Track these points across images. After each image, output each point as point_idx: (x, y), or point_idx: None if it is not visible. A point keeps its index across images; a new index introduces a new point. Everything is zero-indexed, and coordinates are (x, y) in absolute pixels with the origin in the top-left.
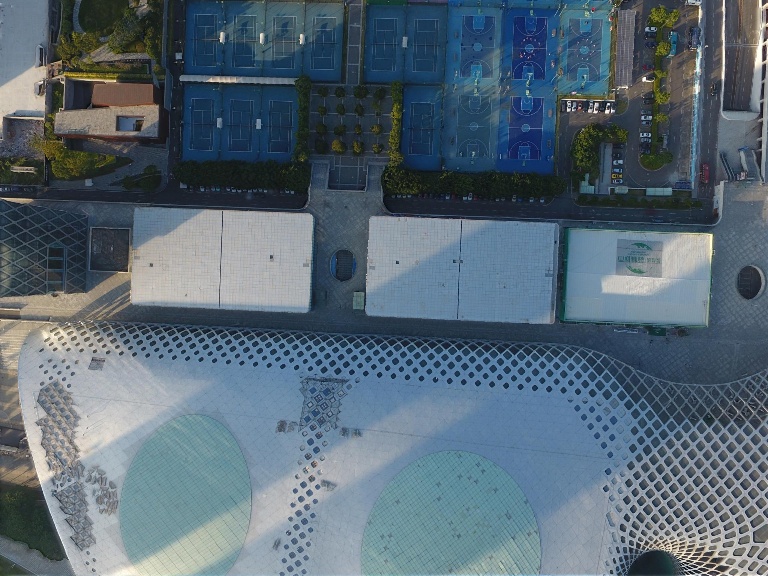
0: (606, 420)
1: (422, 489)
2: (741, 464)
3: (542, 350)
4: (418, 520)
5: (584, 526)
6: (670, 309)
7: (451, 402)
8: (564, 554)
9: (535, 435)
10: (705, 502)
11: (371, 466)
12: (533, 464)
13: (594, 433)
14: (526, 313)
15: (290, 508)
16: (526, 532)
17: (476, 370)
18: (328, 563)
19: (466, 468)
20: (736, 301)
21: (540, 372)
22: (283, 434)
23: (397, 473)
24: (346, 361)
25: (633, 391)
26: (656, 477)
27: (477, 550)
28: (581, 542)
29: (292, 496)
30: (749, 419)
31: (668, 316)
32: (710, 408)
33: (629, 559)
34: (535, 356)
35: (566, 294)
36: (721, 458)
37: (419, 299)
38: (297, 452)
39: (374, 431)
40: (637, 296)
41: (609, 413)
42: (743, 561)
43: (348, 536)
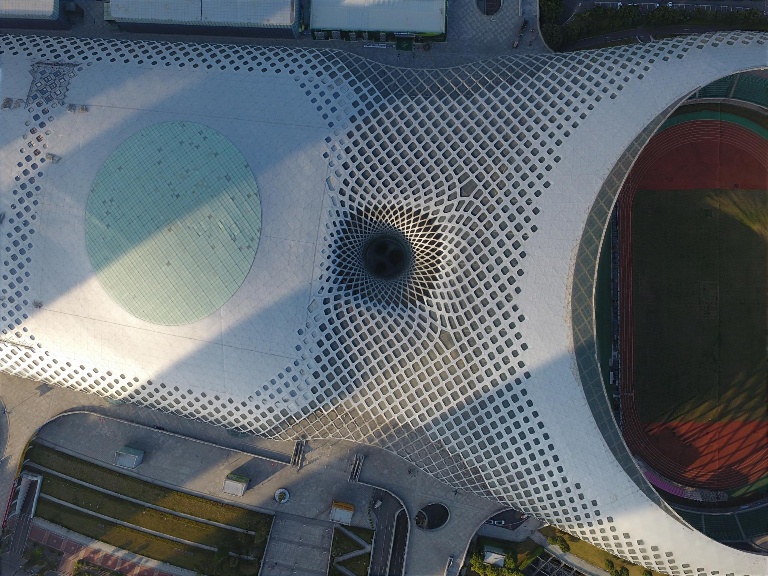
0: (329, 95)
1: (144, 155)
2: (452, 129)
3: (281, 47)
4: (138, 183)
5: (304, 190)
6: (410, 17)
7: (180, 81)
8: (285, 217)
9: (259, 108)
10: (418, 165)
11: (96, 138)
12: (256, 133)
13: (317, 106)
14: (267, 14)
15: (15, 181)
16: (246, 194)
17: (210, 57)
18: (54, 235)
19: (188, 135)
20: (476, 17)
21: (272, 59)
22: (8, 110)
23: (121, 143)
24: (81, 50)
25: (359, 73)
26: (374, 144)
27: (196, 209)
28: (302, 206)
29: (17, 170)
30: (463, 93)
31: (408, 24)
32: (429, 86)
33: (352, 226)
34: (272, 49)
35: (312, 4)
36: (435, 126)
37: (163, 1)
38: (22, 127)
39: (101, 106)
40: (379, 5)
41: (332, 89)
42: (452, 216)
43: (72, 206)
